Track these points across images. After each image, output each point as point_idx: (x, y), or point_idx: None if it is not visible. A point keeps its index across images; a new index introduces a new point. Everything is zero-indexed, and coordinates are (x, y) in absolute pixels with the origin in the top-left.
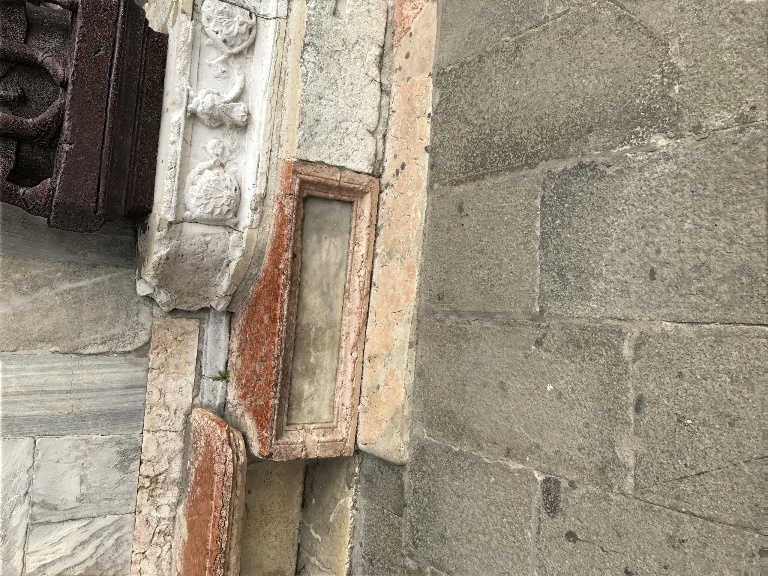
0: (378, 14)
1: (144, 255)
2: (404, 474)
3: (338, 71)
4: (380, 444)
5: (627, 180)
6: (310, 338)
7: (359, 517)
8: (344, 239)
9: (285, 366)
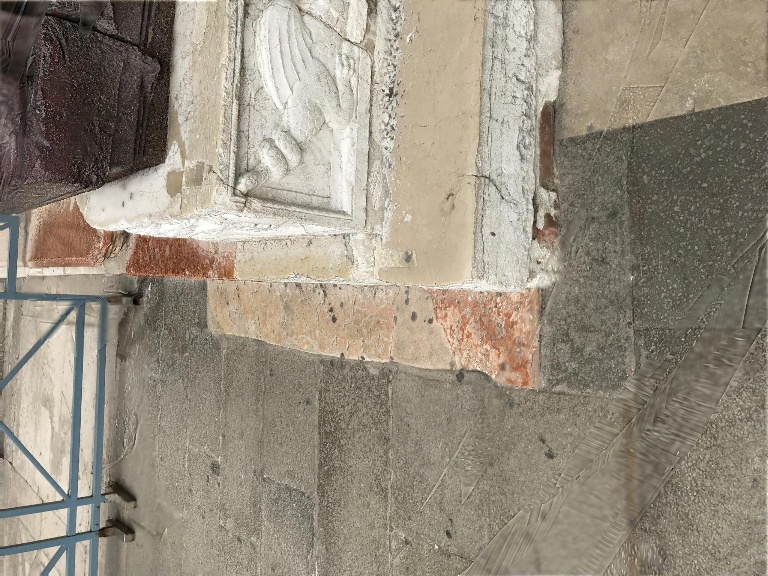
0: None
1: None
2: None
3: None
4: (209, 310)
5: (304, 569)
6: None
7: None
8: None
9: None
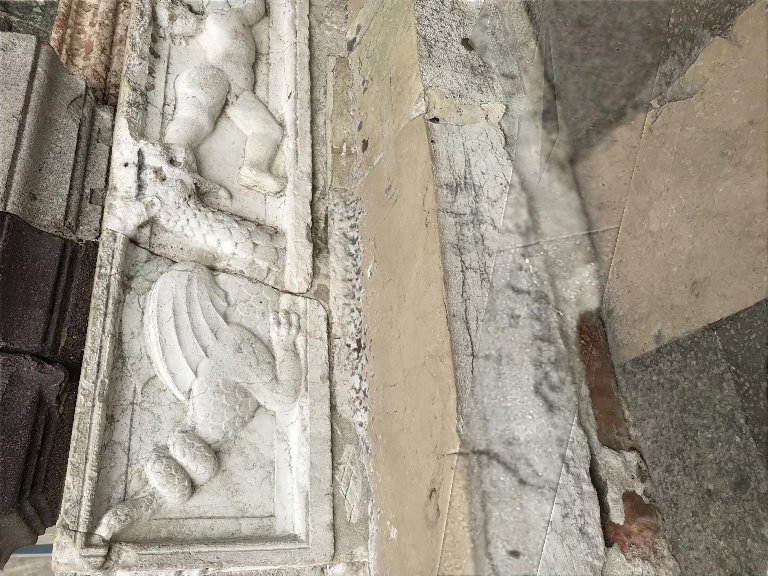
0: None
1: None
2: None
3: None
4: None
5: None
6: None
7: None
8: None
9: None
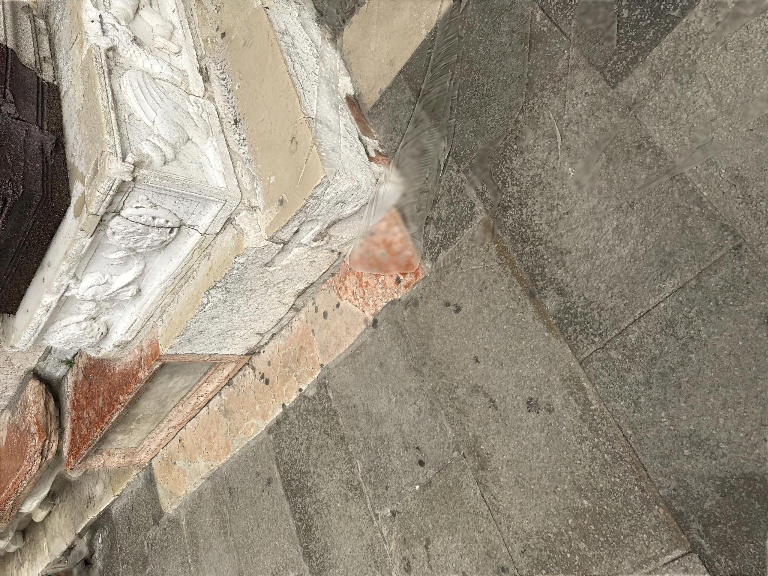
0: (322, 264)
1: (4, 317)
2: (165, 513)
3: (246, 301)
4: (159, 489)
5: None
6: (135, 418)
7: (137, 481)
8: (197, 376)
9: (103, 435)
